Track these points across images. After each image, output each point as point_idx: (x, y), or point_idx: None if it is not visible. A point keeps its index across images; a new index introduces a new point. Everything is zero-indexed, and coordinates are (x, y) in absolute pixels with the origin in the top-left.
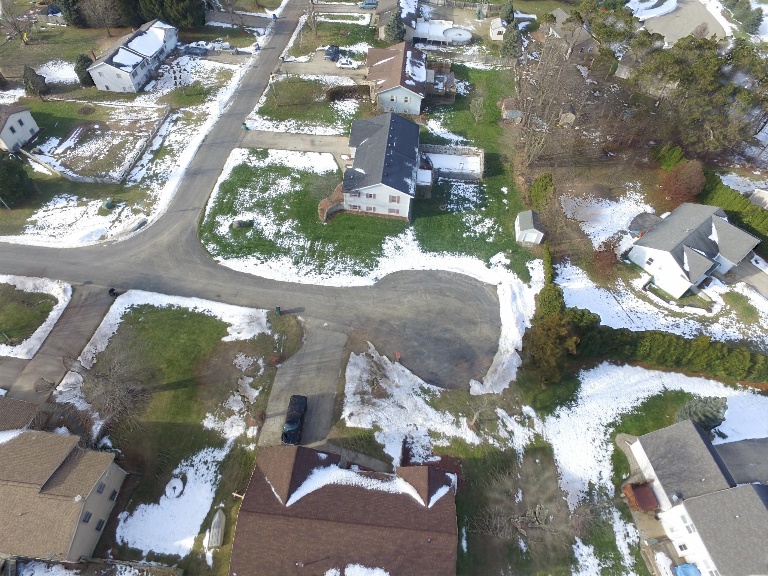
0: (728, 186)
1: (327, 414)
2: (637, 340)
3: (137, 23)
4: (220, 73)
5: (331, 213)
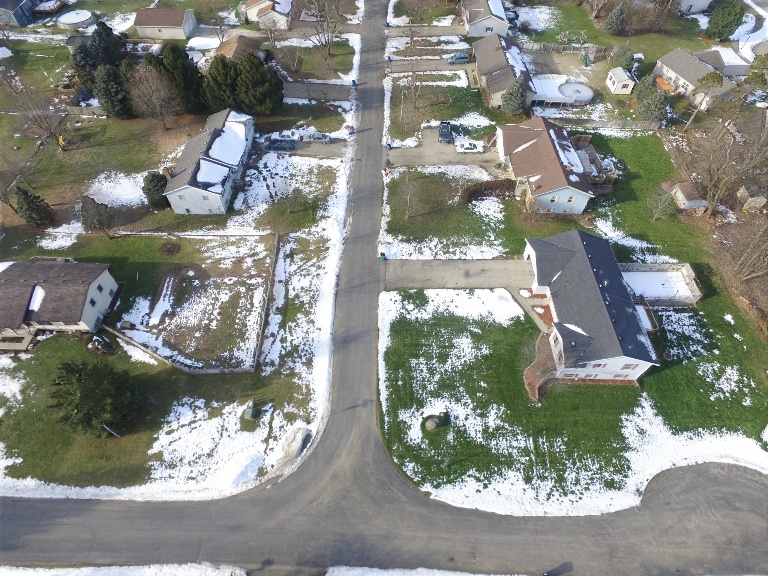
0: None
1: None
2: None
3: (197, 110)
4: (320, 174)
5: (540, 386)
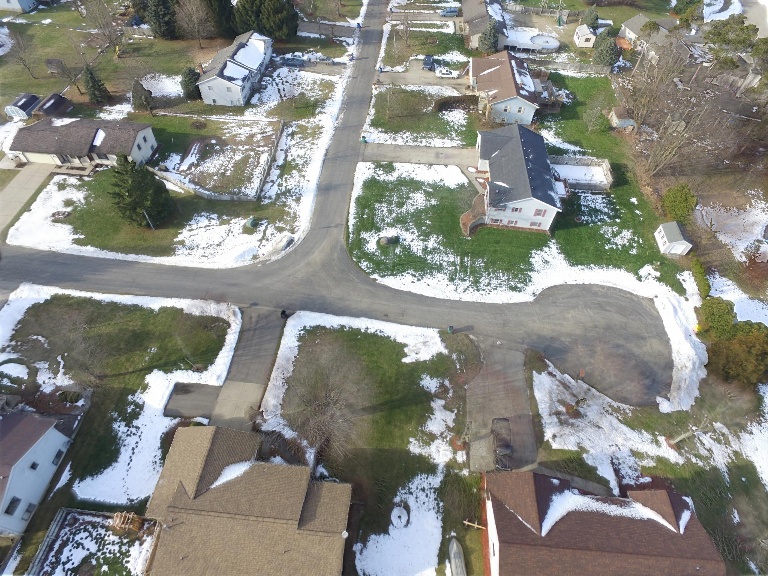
0: None
1: (529, 436)
2: None
3: (227, 34)
4: (322, 85)
5: (472, 227)
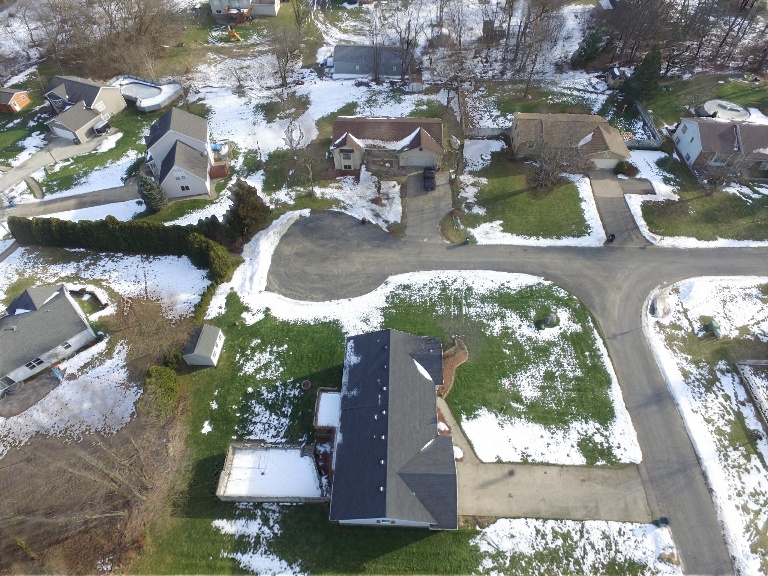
0: None
1: (410, 187)
2: None
3: None
4: None
5: None
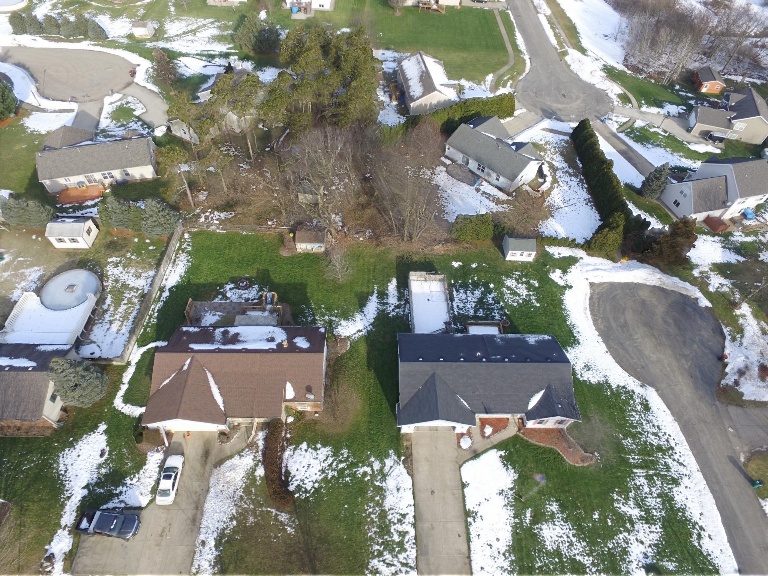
0: (431, 113)
1: None
2: (622, 197)
3: None
4: None
5: None
